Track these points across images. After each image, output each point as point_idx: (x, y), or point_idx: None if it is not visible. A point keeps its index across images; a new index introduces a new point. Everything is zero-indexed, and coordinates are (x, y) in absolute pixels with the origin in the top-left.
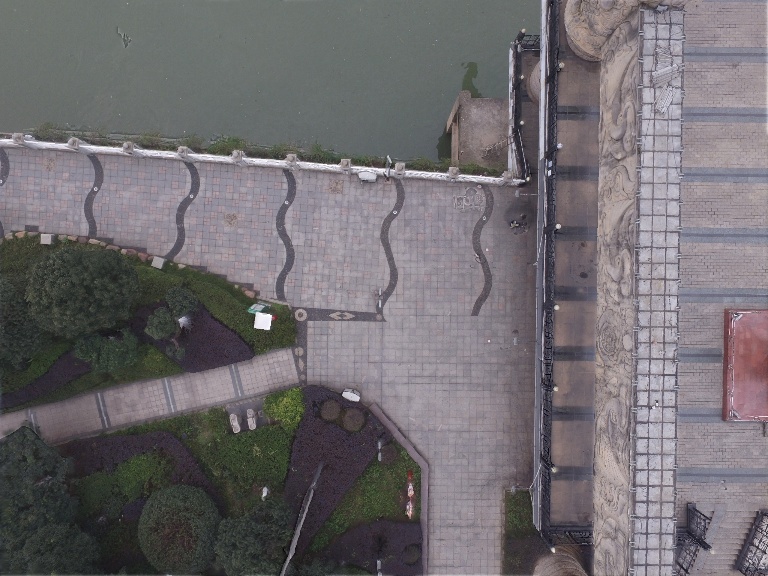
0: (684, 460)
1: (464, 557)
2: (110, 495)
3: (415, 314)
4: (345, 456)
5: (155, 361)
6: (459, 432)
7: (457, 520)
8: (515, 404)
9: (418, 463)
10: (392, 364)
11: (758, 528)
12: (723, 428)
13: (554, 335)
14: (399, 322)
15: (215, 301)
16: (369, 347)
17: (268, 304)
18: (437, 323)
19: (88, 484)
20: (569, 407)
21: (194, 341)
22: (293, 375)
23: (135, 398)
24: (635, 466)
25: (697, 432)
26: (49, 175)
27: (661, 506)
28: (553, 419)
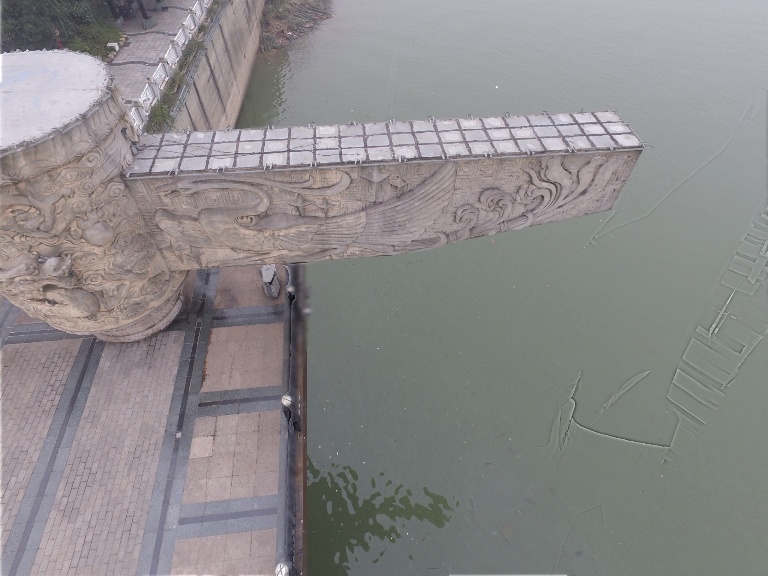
0: None
1: None
2: None
3: None
4: None
5: None
6: None
7: None
8: None
9: None
10: None
11: None
12: None
13: None
14: None
15: None
16: None
17: None
18: None
19: None
20: None
21: None
22: None
23: None
24: None
25: None
26: (165, 48)
27: None
28: None
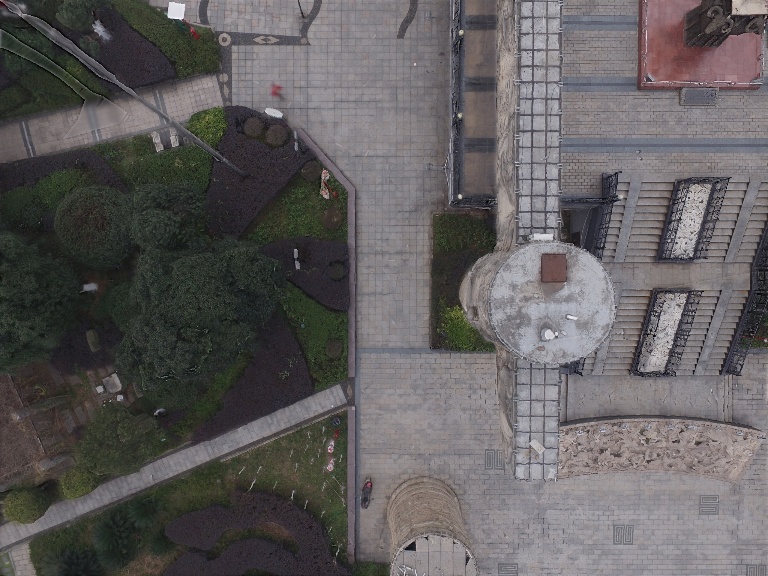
0: (599, 130)
1: (393, 284)
2: (31, 204)
3: (340, 37)
4: (267, 167)
5: (75, 74)
6: (386, 157)
7: (385, 247)
8: (442, 128)
9: (344, 186)
10: (318, 89)
11: (675, 200)
12: (638, 97)
13: (466, 4)
14: (324, 46)
15: (134, 13)
16: (294, 72)
17: (191, 27)
18: (362, 46)
19: (10, 197)
20: (482, 78)
21: (113, 51)
22: (218, 102)
23: (60, 126)
24: (520, 30)
25: (612, 102)
26: None
27: (547, 71)
28: (466, 90)
